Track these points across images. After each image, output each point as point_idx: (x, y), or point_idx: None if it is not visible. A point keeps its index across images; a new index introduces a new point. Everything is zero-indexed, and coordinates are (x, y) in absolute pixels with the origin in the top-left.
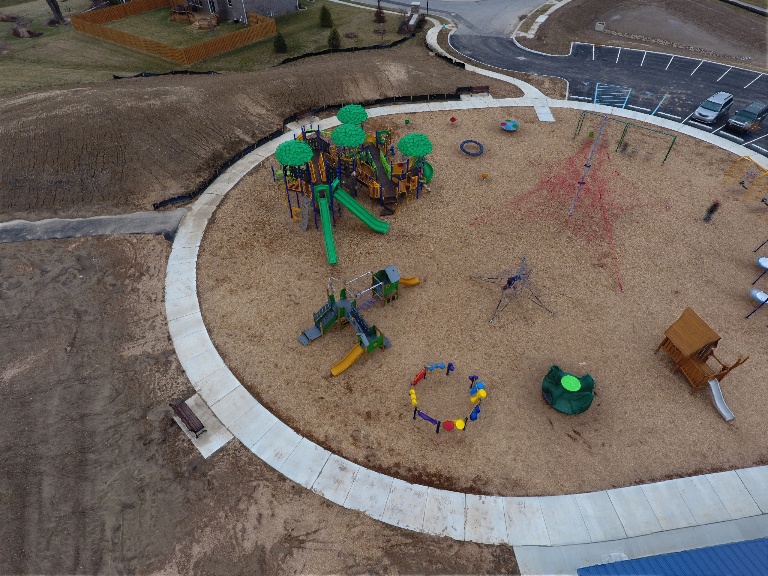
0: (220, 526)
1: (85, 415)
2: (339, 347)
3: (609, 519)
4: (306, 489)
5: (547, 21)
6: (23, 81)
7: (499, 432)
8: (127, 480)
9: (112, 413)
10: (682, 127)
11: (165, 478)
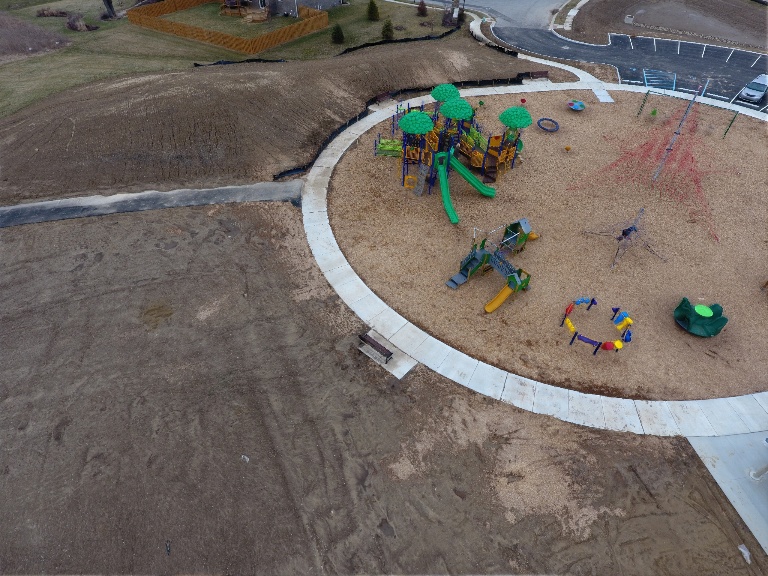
0: (433, 429)
1: (282, 347)
2: (485, 290)
3: (760, 415)
4: (496, 400)
5: (579, 15)
6: (107, 69)
7: (647, 353)
8: (339, 396)
9: (305, 345)
10: (732, 106)
11: (371, 394)
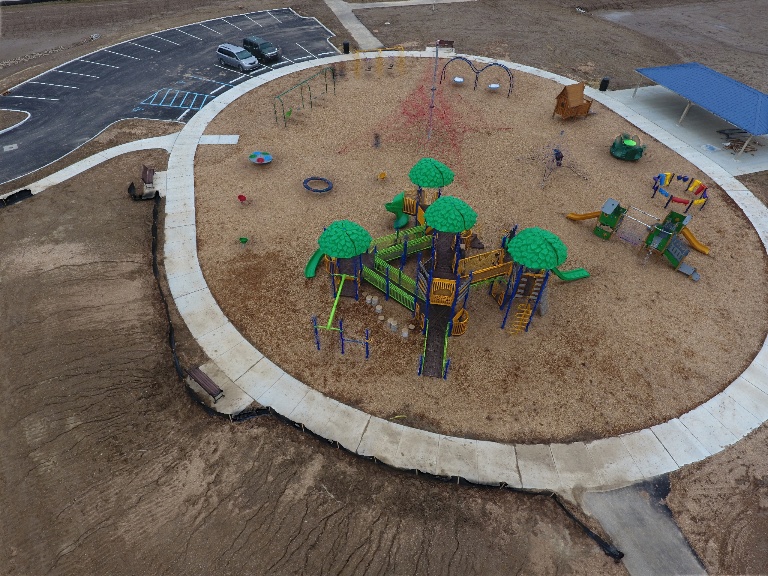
0: None
1: None
2: None
3: None
4: None
5: None
6: None
7: None
8: None
9: None
10: (262, 78)
11: None
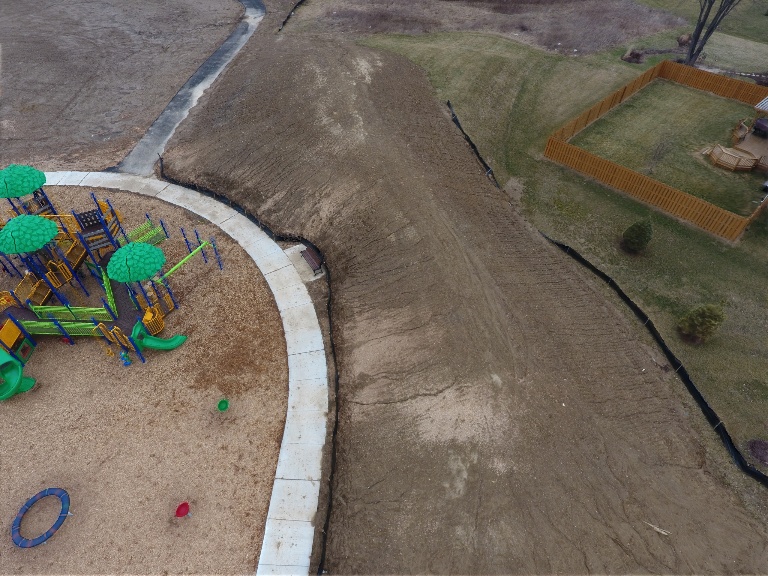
0: None
1: None
2: None
3: None
4: None
5: None
6: (448, 64)
7: None
8: None
9: None
10: None
11: None
